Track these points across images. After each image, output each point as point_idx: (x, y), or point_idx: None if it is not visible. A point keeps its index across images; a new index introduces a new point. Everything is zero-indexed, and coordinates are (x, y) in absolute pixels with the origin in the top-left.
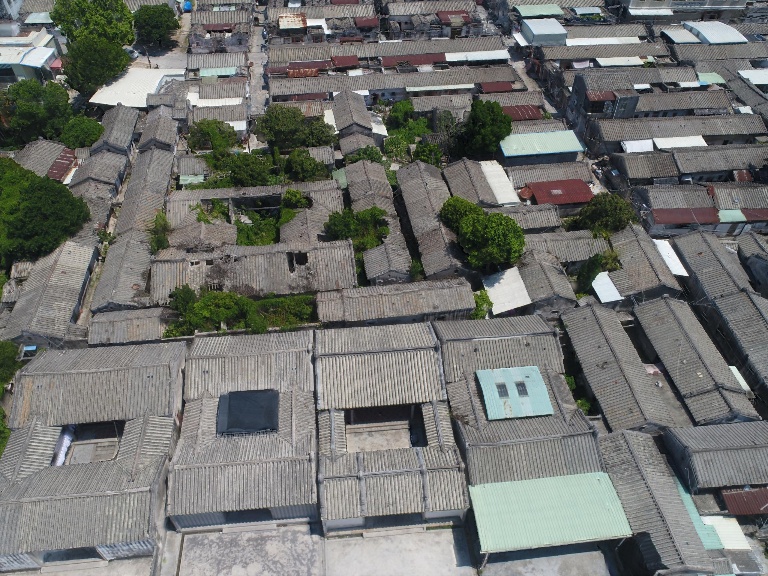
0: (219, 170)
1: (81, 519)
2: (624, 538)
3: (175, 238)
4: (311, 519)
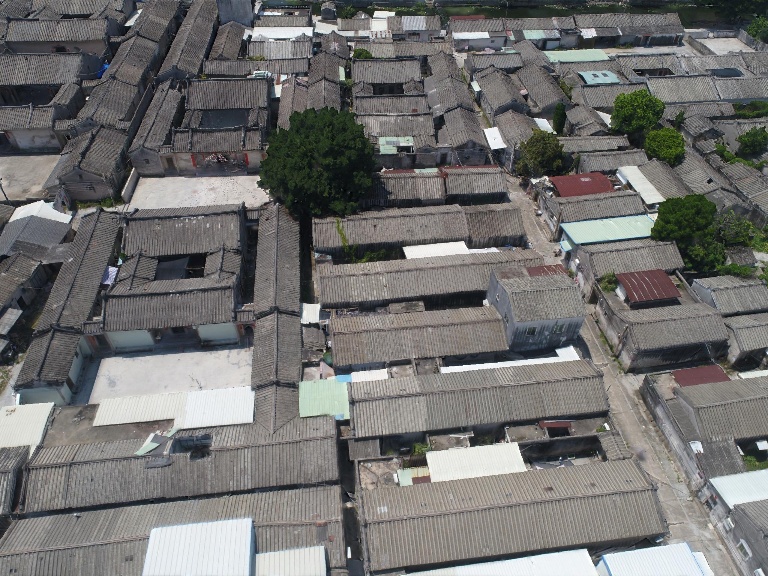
0: None
1: None
2: None
3: None
4: None
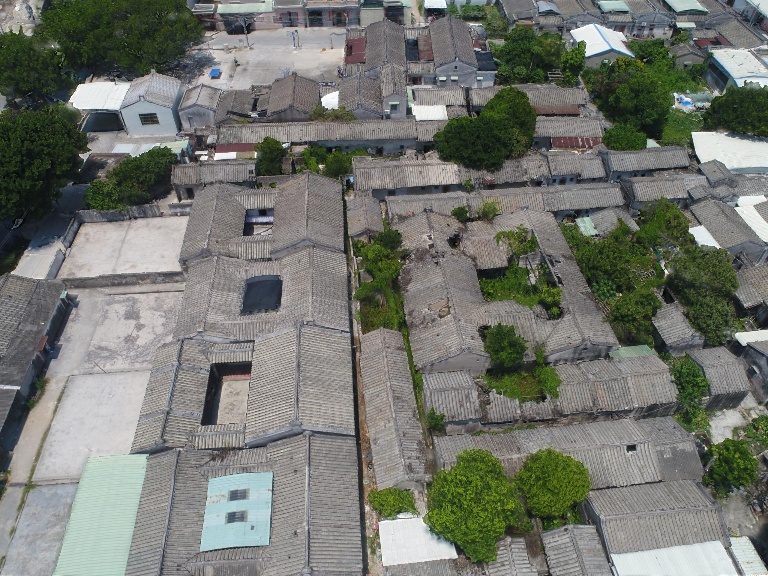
0: None
1: None
2: None
3: (479, 226)
4: None
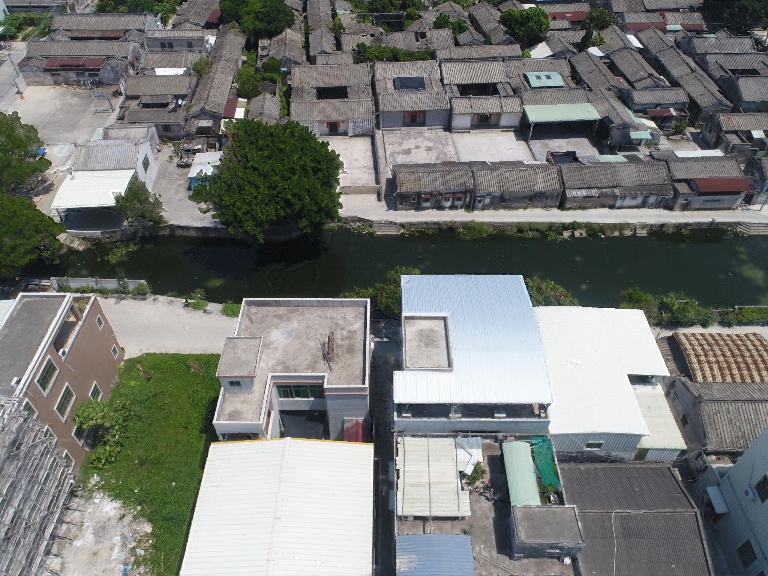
0: (359, 9)
1: (341, 109)
2: (597, 122)
3: None
4: (444, 127)
